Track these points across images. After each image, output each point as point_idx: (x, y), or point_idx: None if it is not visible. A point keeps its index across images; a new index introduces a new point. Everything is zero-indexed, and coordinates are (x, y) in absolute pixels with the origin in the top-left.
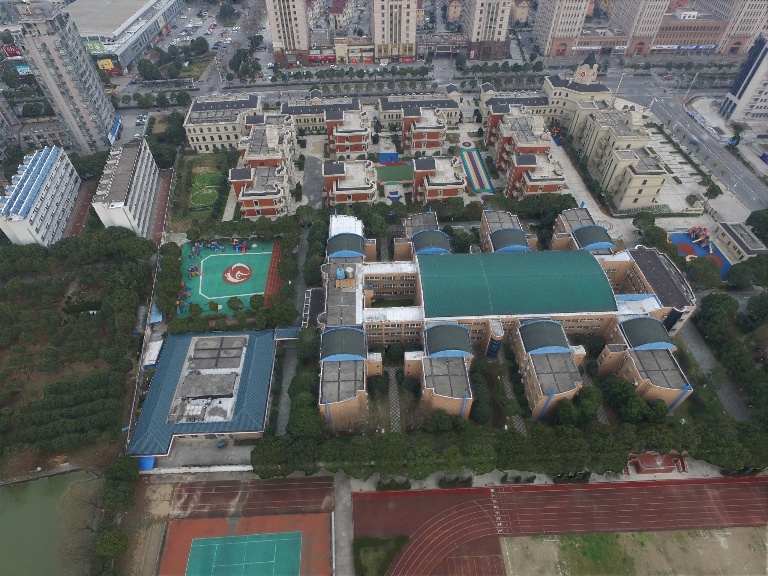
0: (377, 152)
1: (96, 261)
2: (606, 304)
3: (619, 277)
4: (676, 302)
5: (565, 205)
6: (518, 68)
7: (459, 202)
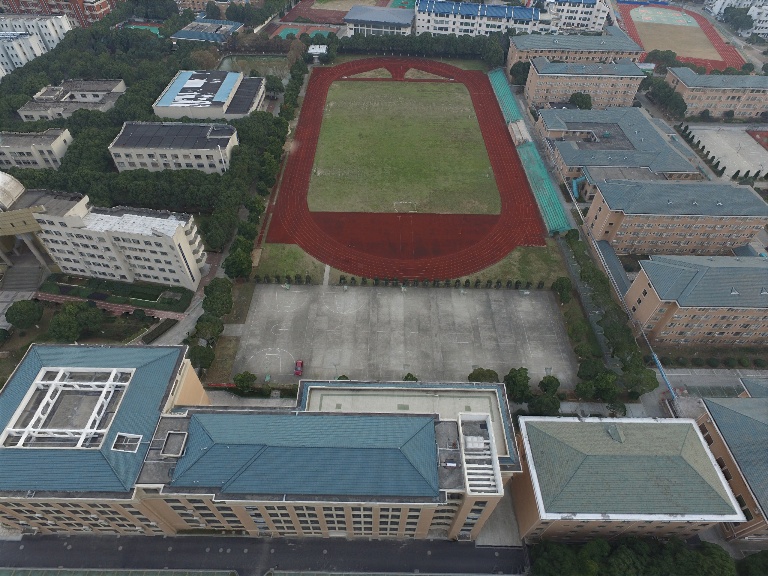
0: None
1: (86, 48)
2: None
3: None
4: None
5: None
6: None
7: None
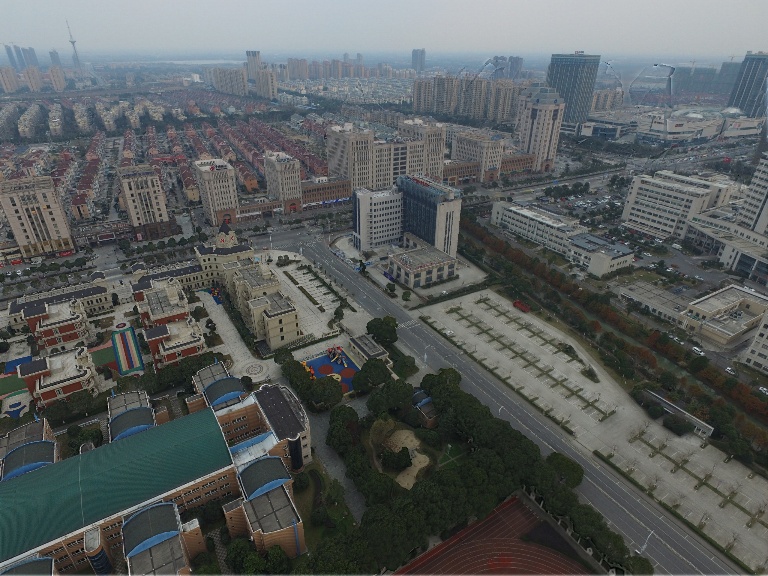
0: (3, 361)
1: None
2: (220, 461)
3: (254, 421)
4: (292, 432)
5: (202, 365)
6: (182, 242)
7: (82, 396)
